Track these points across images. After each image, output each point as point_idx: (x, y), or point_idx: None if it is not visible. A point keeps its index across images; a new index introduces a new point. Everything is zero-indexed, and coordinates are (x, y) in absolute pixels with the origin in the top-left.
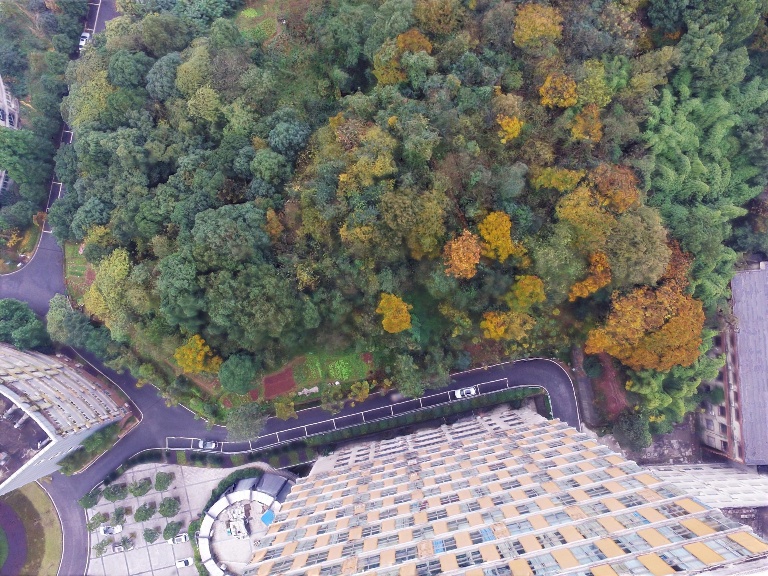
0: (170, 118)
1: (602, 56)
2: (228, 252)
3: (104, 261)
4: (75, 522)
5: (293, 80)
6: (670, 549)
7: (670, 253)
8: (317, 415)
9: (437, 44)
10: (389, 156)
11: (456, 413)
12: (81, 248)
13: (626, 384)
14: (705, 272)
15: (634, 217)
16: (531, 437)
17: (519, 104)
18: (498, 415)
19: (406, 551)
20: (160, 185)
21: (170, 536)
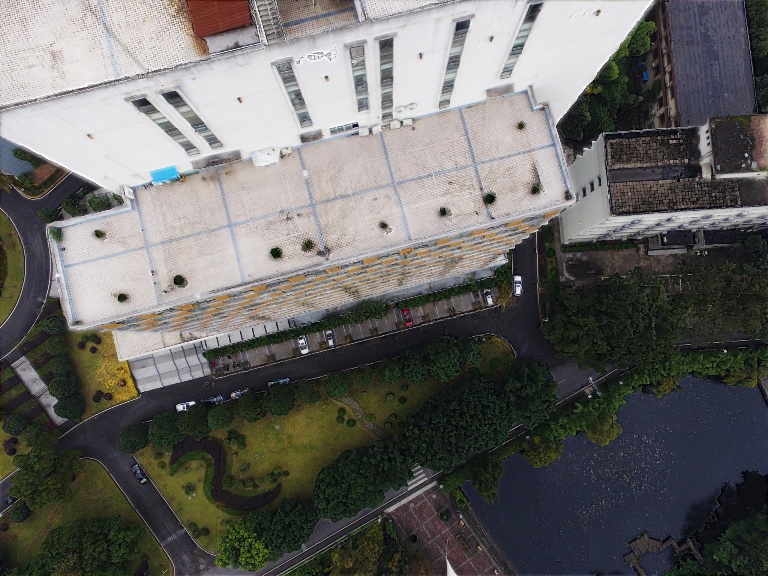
0: None
1: None
2: None
3: None
4: (37, 245)
5: None
6: None
7: None
8: None
9: None
10: None
11: None
12: None
13: None
14: None
15: None
16: None
17: None
18: None
19: None
20: None
21: None
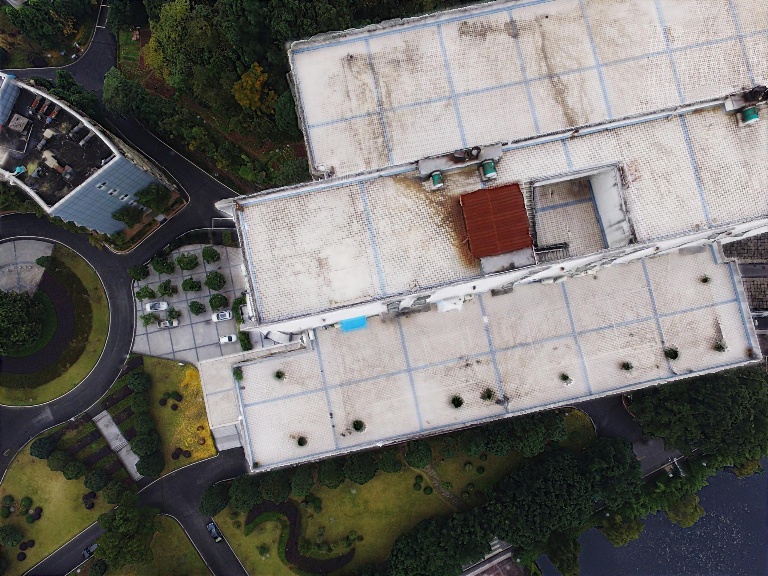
0: None
1: None
2: None
3: (165, 7)
4: (122, 300)
5: None
6: None
7: None
8: None
9: None
10: None
11: None
12: (135, 34)
13: None
14: None
15: None
16: None
17: None
18: None
19: None
20: None
21: (216, 302)
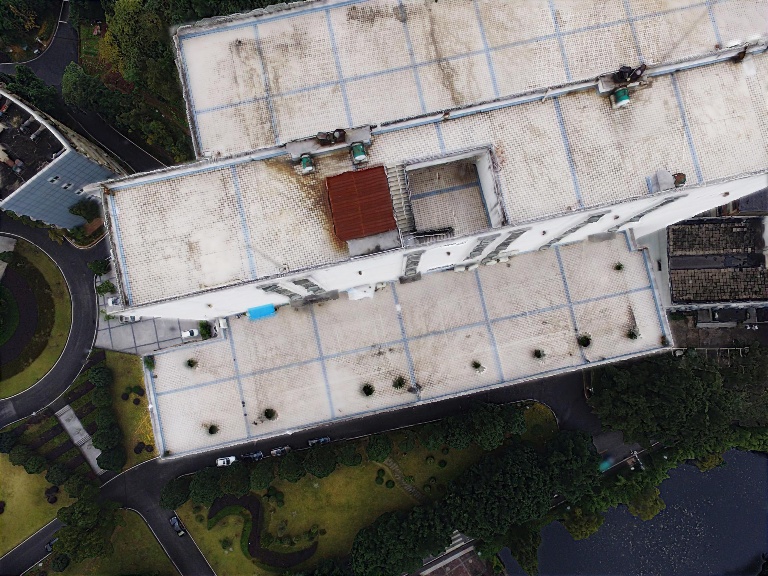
0: None
1: None
2: None
3: (119, 1)
4: (84, 295)
5: None
6: None
7: None
8: None
9: None
10: None
11: None
12: (96, 29)
13: None
14: None
15: None
16: None
17: None
18: None
19: None
20: None
21: None
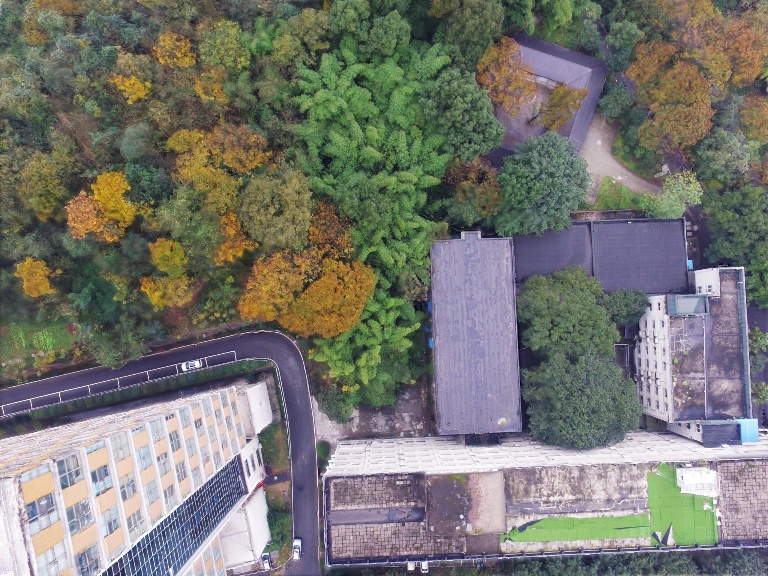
0: None
1: (255, 19)
2: None
3: None
4: None
5: (6, 48)
6: None
7: (307, 216)
8: (43, 388)
9: None
10: None
11: (185, 386)
12: None
13: (308, 352)
14: (375, 239)
15: (274, 180)
16: (174, 402)
17: (143, 64)
18: None
19: None
20: None
21: None
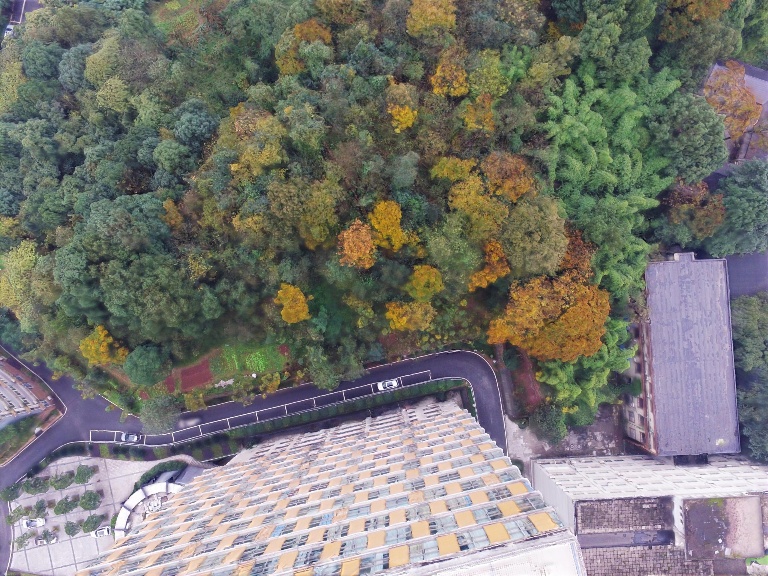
0: (81, 109)
1: (503, 46)
2: (119, 242)
3: (12, 252)
4: None
5: (212, 72)
6: (470, 530)
7: (567, 243)
8: (240, 408)
9: (341, 34)
10: (277, 145)
11: (379, 405)
12: None
13: (536, 375)
14: (611, 263)
15: (531, 207)
16: (430, 427)
17: (412, 93)
18: (423, 407)
19: (246, 536)
20: (66, 176)
21: (89, 529)
